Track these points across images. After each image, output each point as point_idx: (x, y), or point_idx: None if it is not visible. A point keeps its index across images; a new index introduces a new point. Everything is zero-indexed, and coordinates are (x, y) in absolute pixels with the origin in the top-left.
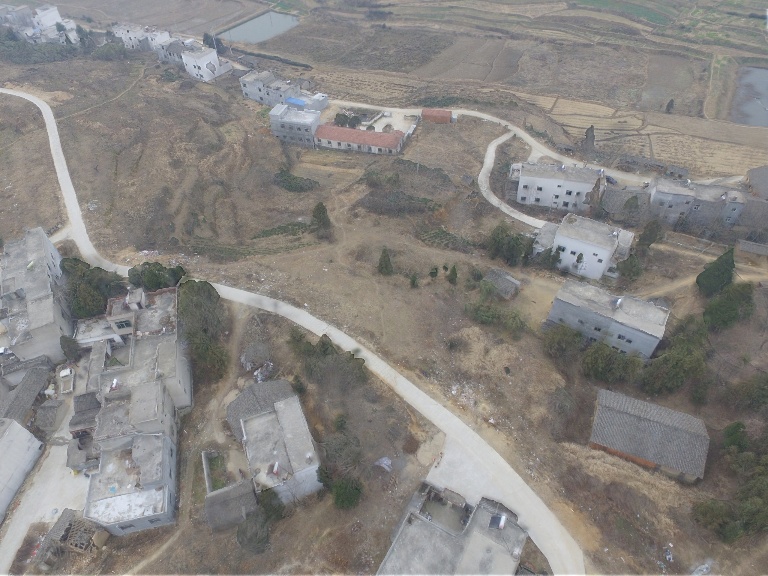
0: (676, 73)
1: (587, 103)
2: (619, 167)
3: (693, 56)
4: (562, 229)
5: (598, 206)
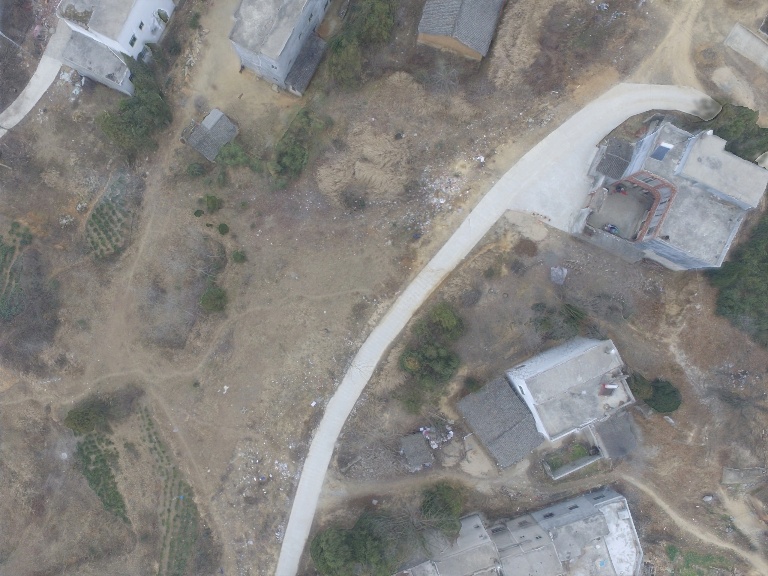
0: None
1: None
2: None
3: None
4: (105, 29)
5: None
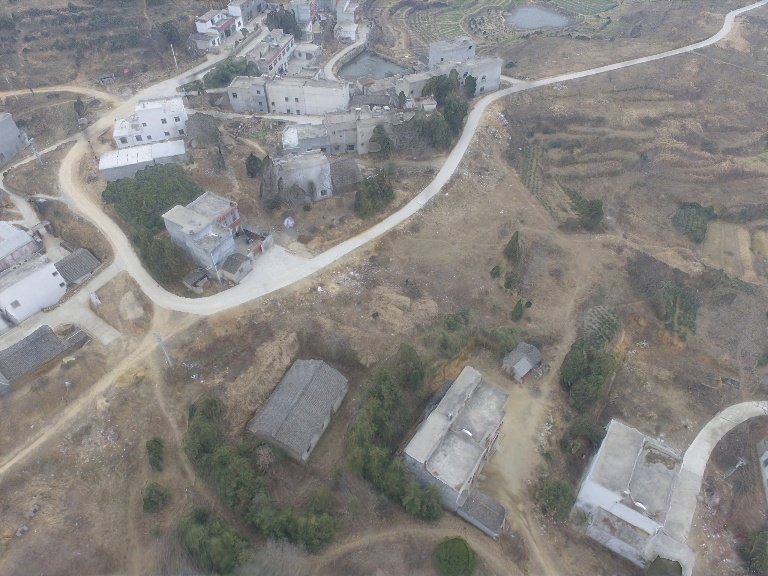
0: None
1: None
2: None
3: None
4: (627, 430)
5: (755, 544)
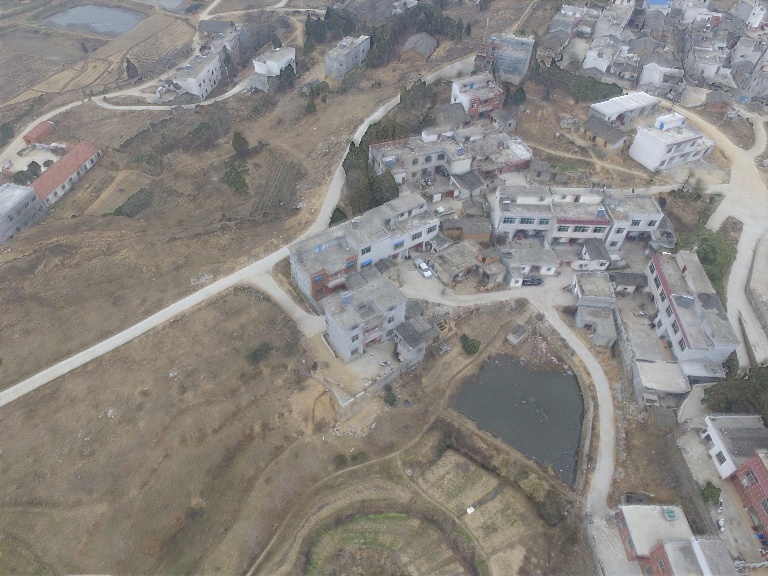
0: (27, 42)
1: (50, 78)
2: (171, 66)
3: (7, 31)
4: (273, 60)
5: None
